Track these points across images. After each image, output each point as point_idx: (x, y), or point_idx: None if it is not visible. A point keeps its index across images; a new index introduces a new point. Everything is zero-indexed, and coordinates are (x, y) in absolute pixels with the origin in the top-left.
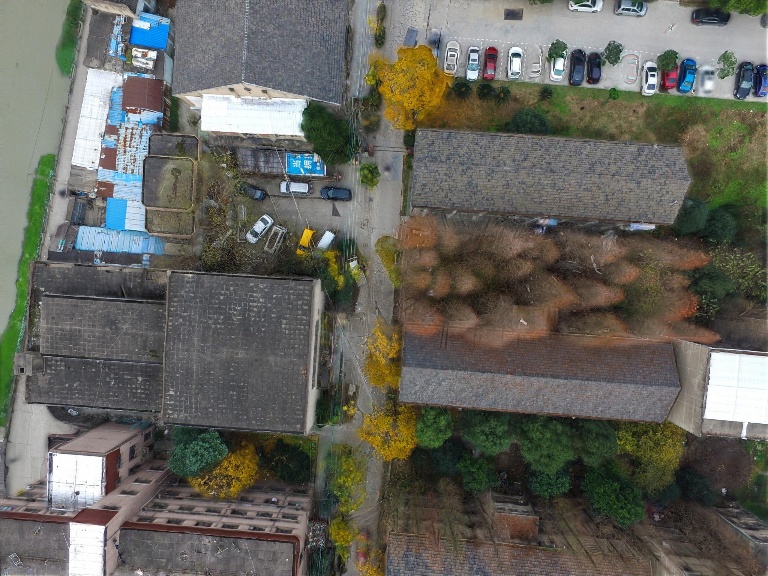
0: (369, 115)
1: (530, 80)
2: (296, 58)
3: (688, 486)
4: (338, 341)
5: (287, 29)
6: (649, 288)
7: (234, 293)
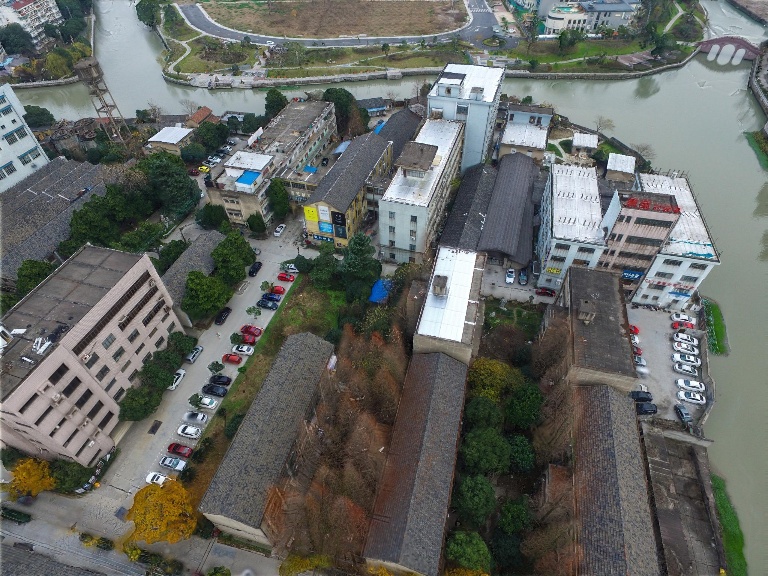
0: (165, 570)
1: (207, 423)
2: None
3: (523, 361)
4: None
5: None
6: (377, 365)
7: None
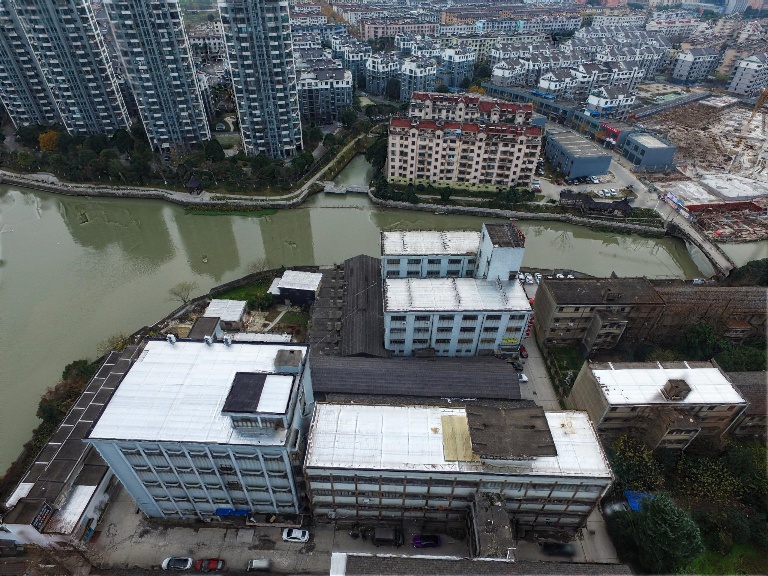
0: None
1: None
2: None
3: None
4: None
5: None
6: (762, 462)
7: None
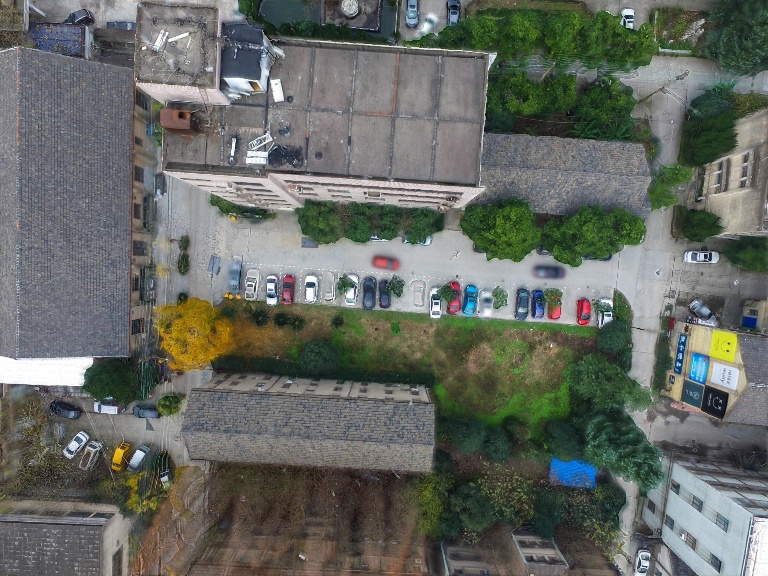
0: None
1: (328, 303)
2: (75, 324)
3: None
4: (156, 546)
5: (64, 300)
6: (428, 509)
7: (28, 539)
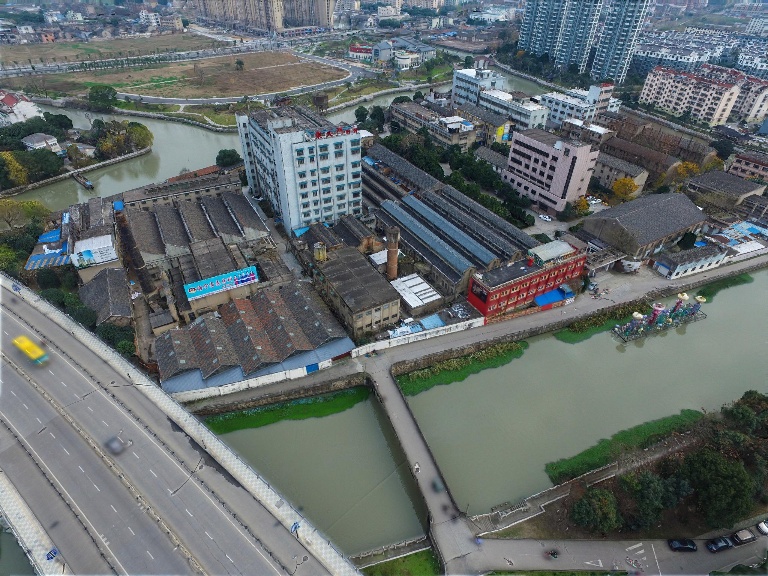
0: None
1: None
2: None
3: None
4: None
5: None
6: None
7: None
